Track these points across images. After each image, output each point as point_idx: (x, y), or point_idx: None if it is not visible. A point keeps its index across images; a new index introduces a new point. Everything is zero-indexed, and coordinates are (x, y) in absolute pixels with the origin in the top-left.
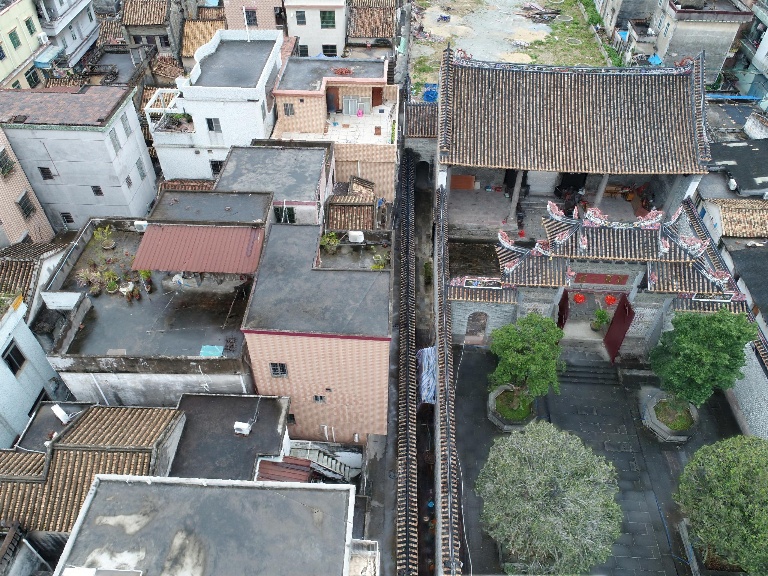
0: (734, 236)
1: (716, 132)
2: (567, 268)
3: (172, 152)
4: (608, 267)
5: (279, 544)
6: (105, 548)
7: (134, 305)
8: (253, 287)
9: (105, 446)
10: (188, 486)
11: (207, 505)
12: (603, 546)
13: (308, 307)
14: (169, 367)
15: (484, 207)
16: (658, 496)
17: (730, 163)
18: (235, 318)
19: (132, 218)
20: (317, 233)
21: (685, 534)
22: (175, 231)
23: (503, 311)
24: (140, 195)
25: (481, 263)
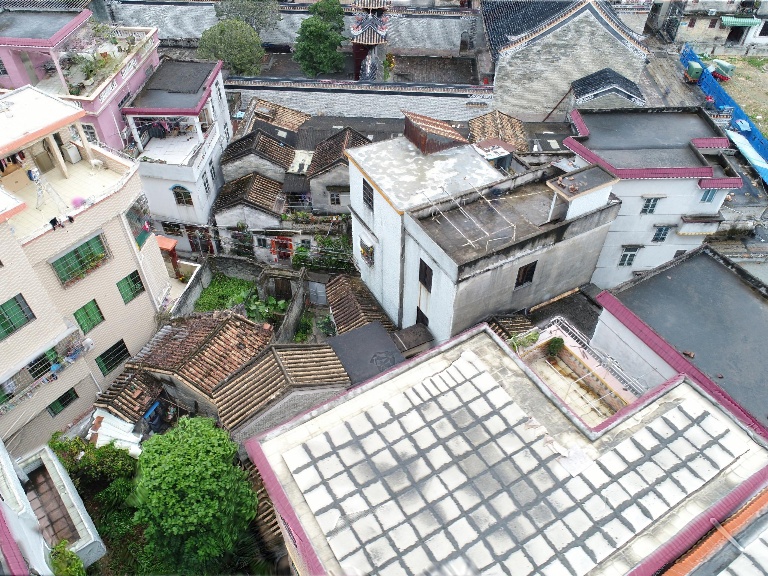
0: (469, 124)
1: None
2: None
3: None
4: None
5: None
6: None
7: None
8: None
9: None
10: None
11: None
12: (217, 2)
13: None
14: None
15: None
16: None
17: None
18: None
19: None
20: None
21: None
22: None
23: None
24: None
25: (451, 68)
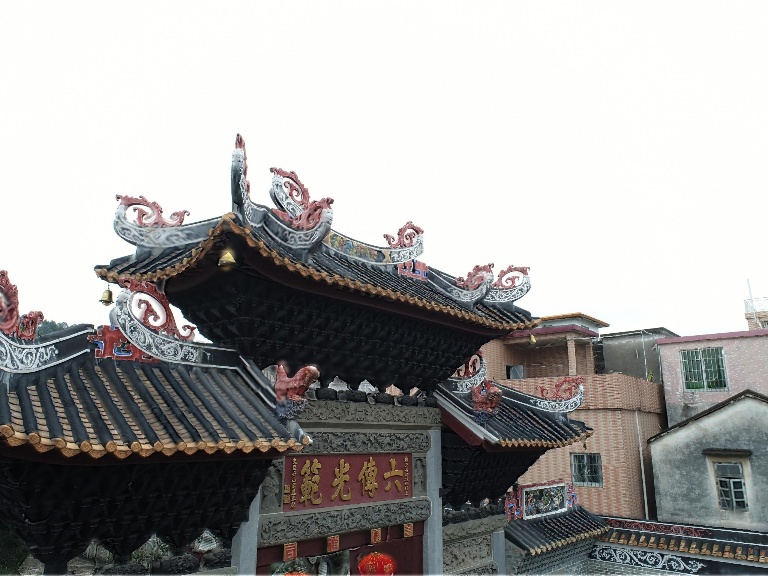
0: None
1: None
2: None
3: None
4: None
5: None
6: None
7: None
8: None
9: None
10: None
11: None
12: None
13: None
14: None
15: None
16: None
17: None
18: None
19: None
20: None
21: None
22: None
23: None
24: None
25: None
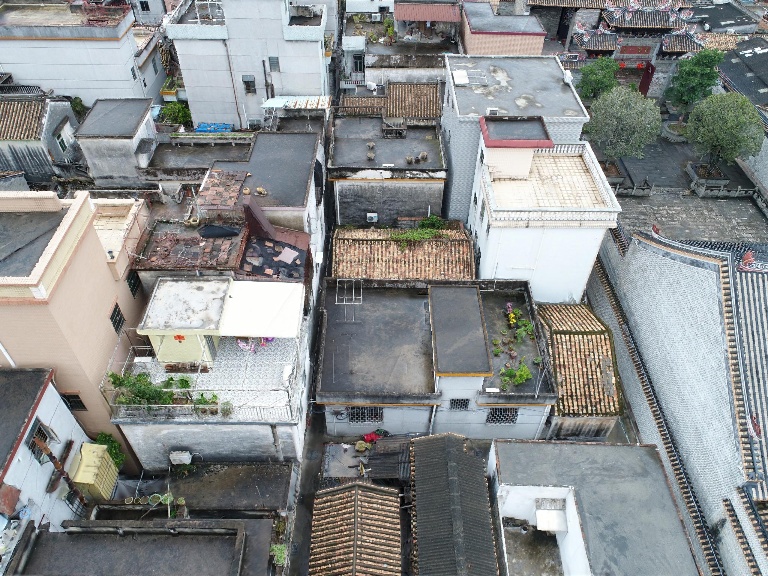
0: None
1: (694, 4)
2: (618, 39)
3: (356, 1)
4: (640, 40)
5: (533, 68)
6: (463, 69)
7: (390, 47)
8: (469, 20)
9: (414, 82)
10: (486, 58)
11: (497, 61)
12: None
13: (500, 26)
14: (426, 62)
15: (546, 48)
16: (673, 160)
17: (705, 16)
18: (447, 50)
19: (370, 12)
20: (489, 5)
21: (689, 169)
22: (410, 6)
23: (576, 79)
24: (336, 28)
25: None
